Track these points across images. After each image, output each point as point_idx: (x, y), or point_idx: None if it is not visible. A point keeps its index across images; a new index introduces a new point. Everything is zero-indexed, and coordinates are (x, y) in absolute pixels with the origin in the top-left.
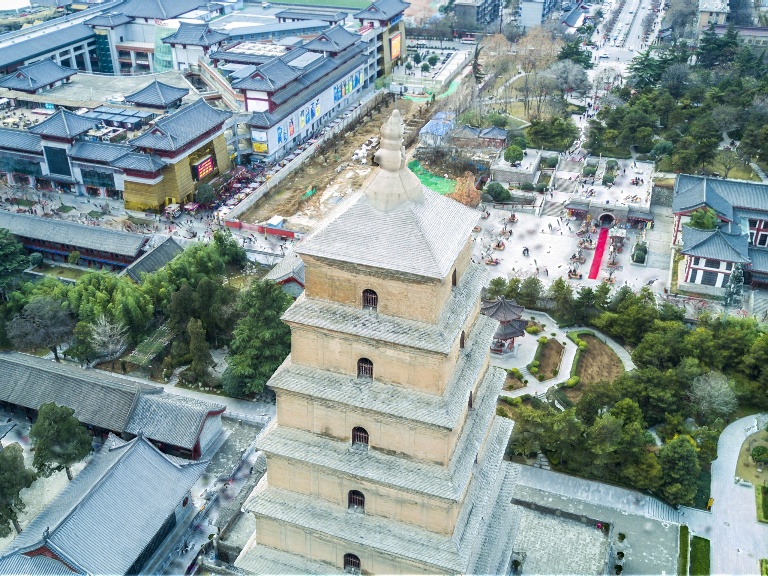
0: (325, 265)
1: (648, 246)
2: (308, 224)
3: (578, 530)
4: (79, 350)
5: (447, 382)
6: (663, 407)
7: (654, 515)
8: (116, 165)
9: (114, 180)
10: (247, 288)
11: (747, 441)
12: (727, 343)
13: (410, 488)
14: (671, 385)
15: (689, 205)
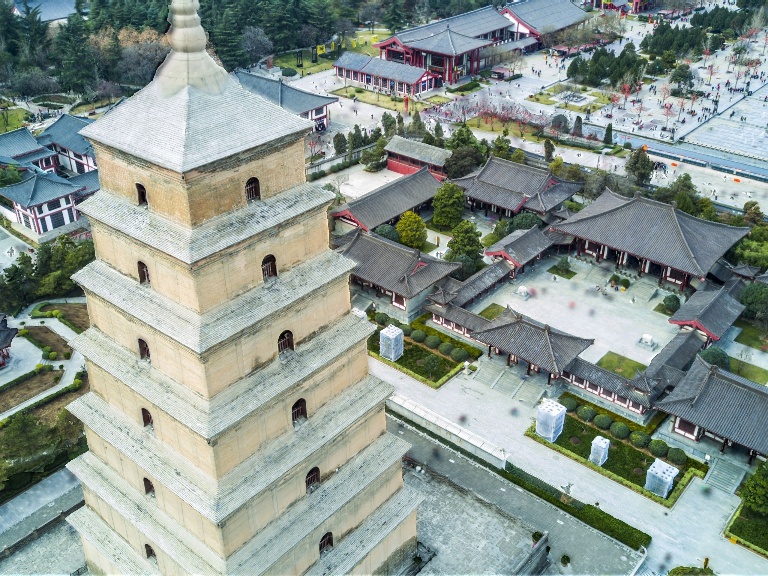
0: (208, 174)
1: None
2: None
3: None
4: None
5: None
6: None
7: None
8: None
9: None
10: None
11: None
12: None
13: None
14: None
15: None
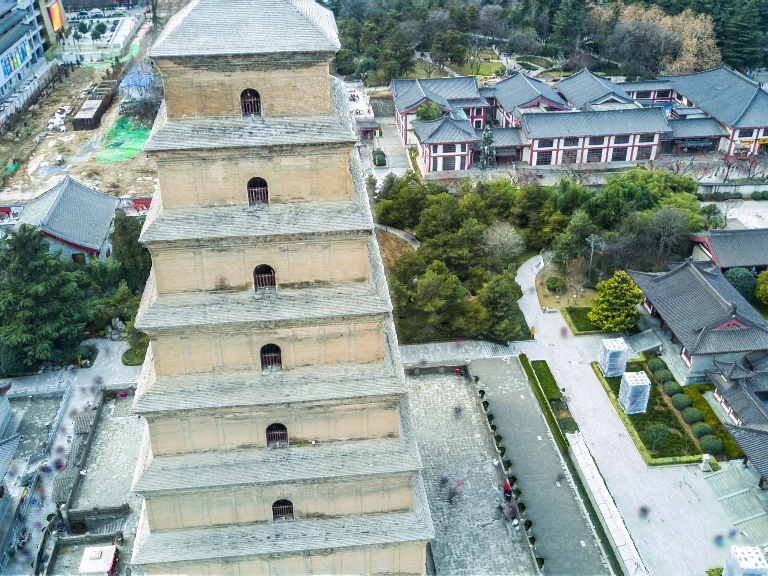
0: (189, 69)
1: (384, 150)
2: (23, 198)
3: (440, 381)
4: None
5: None
6: (465, 263)
7: (493, 355)
8: None
9: None
10: None
11: (538, 278)
12: (494, 201)
13: (336, 315)
14: (465, 243)
15: (412, 103)
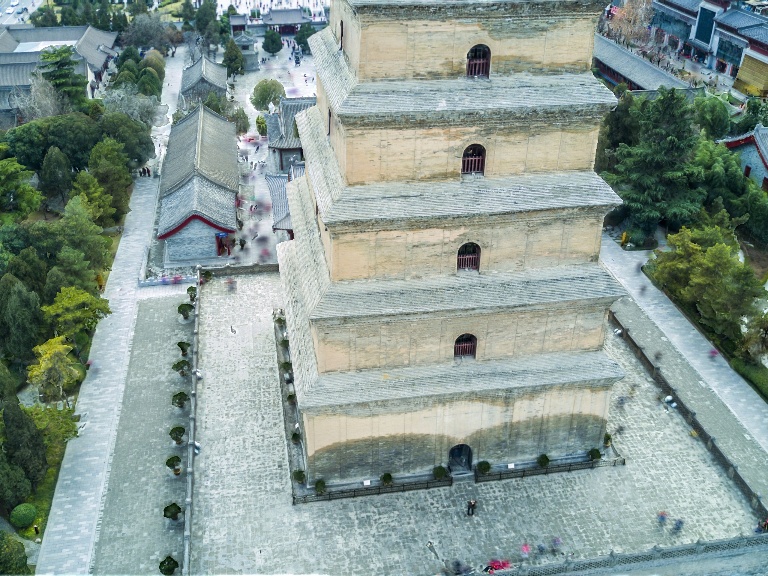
0: None
1: None
2: None
3: (732, 505)
4: None
5: None
6: None
7: None
8: (743, 33)
9: (742, 56)
10: None
11: None
12: None
13: None
14: None
15: None
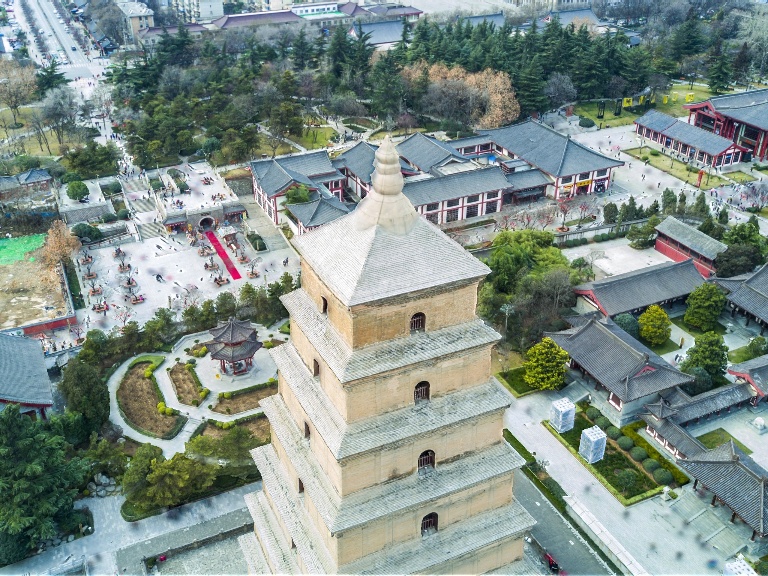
0: (375, 308)
1: (258, 233)
2: None
3: None
4: None
5: None
6: None
7: None
8: None
9: None
10: None
11: None
12: None
13: (486, 478)
14: None
15: (281, 186)
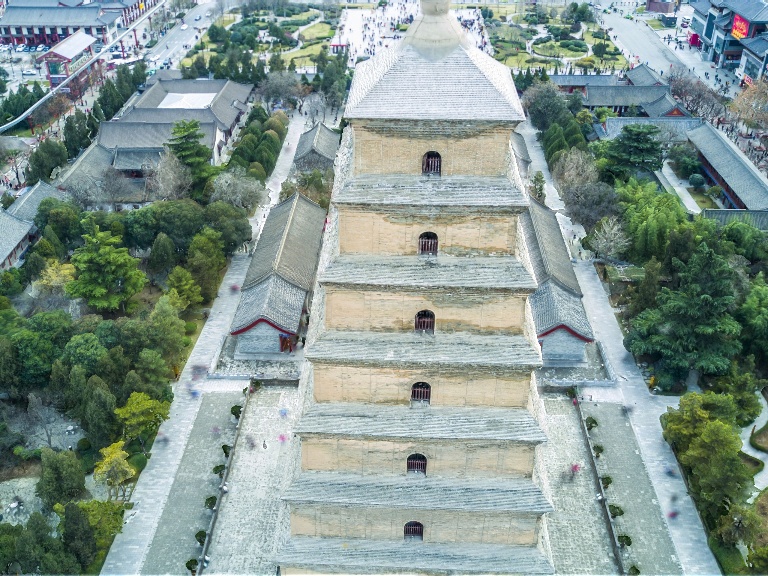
0: None
1: None
2: None
3: None
4: (587, 238)
5: (364, 253)
6: None
7: None
8: None
9: None
10: (731, 266)
11: None
12: None
13: None
14: None
15: None
